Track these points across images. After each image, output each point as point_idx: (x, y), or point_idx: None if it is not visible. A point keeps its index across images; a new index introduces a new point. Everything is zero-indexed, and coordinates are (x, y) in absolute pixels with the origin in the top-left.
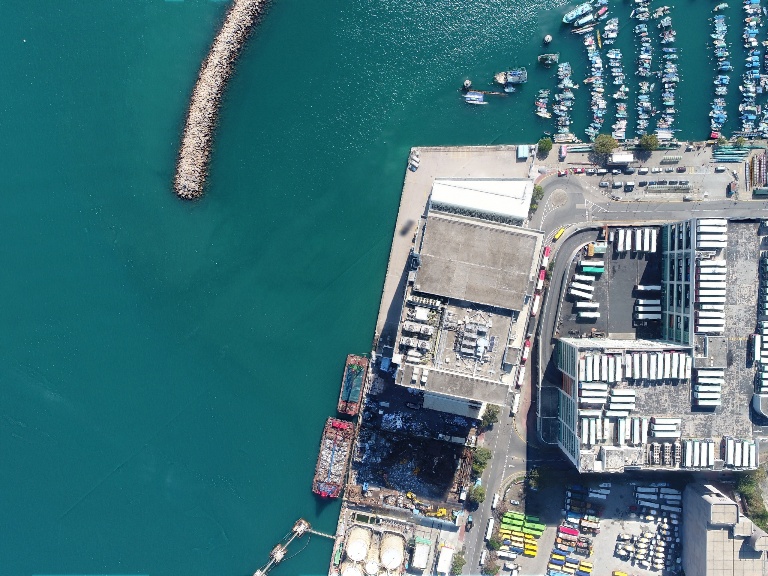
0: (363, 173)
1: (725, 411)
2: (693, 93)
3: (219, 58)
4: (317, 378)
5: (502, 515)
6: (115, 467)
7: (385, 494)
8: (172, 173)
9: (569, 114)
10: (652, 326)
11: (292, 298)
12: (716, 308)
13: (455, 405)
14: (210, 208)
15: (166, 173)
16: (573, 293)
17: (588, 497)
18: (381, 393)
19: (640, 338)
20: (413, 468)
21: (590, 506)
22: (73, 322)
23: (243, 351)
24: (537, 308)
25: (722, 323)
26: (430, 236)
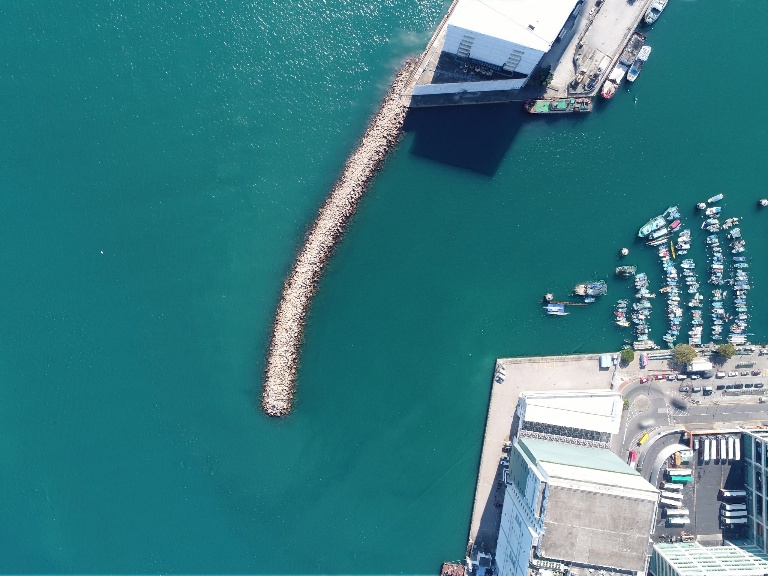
0: (450, 385)
1: None
2: (763, 299)
3: (303, 279)
4: None
5: None
6: None
7: None
8: (259, 390)
9: (647, 322)
10: (738, 527)
11: (385, 508)
12: None
13: None
14: (299, 424)
15: (252, 390)
16: (663, 502)
17: None
18: None
19: (727, 540)
20: None
21: None
22: (175, 560)
23: (338, 563)
24: None
25: None
26: (552, 504)
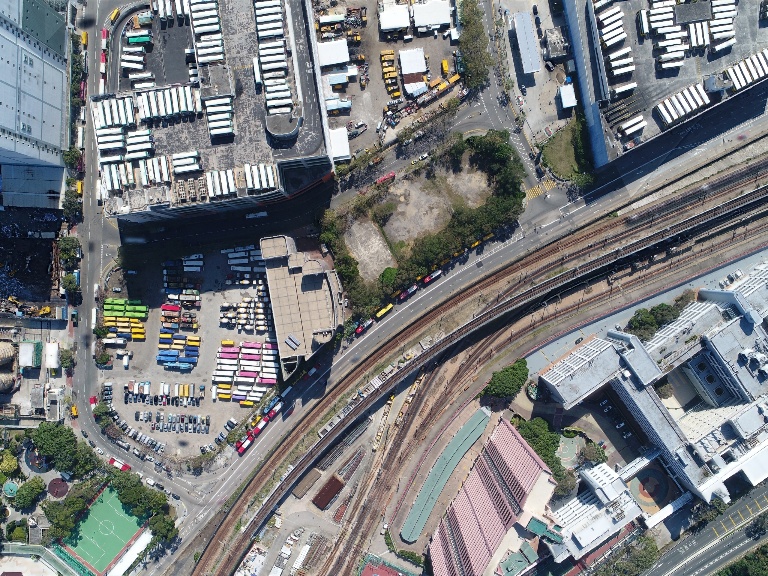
0: None
1: (244, 140)
2: None
3: None
4: None
5: (103, 303)
6: None
7: None
8: None
9: None
10: None
11: None
12: (214, 38)
13: (34, 198)
14: None
15: None
16: (124, 66)
17: (186, 273)
18: None
19: None
20: (10, 271)
21: (186, 280)
22: None
23: None
24: (103, 91)
25: (220, 50)
26: None
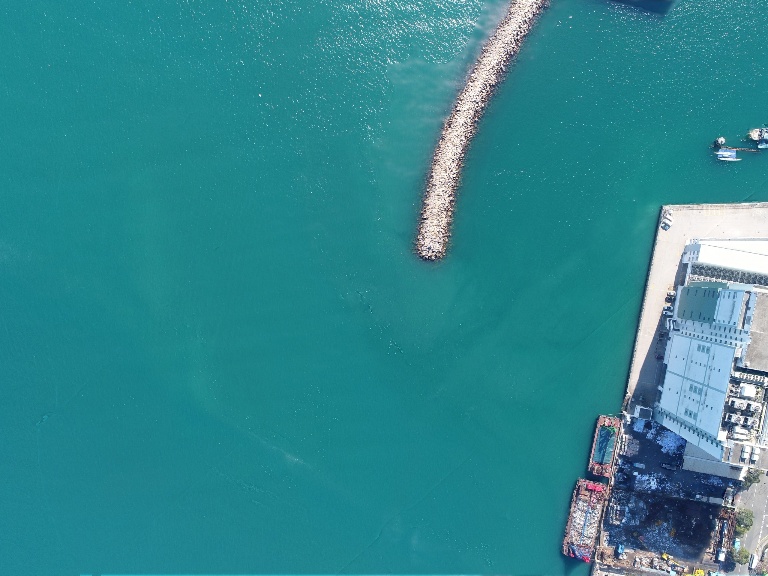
0: (612, 232)
1: None
2: None
3: (465, 118)
4: (566, 439)
5: (762, 575)
6: (376, 536)
7: (641, 556)
8: (413, 234)
9: None
10: None
11: (538, 358)
12: None
13: (716, 466)
14: (453, 269)
15: (406, 234)
16: None
17: None
18: (634, 454)
19: None
20: (668, 529)
21: None
22: (333, 391)
23: (489, 413)
24: None
25: None
26: (760, 312)
